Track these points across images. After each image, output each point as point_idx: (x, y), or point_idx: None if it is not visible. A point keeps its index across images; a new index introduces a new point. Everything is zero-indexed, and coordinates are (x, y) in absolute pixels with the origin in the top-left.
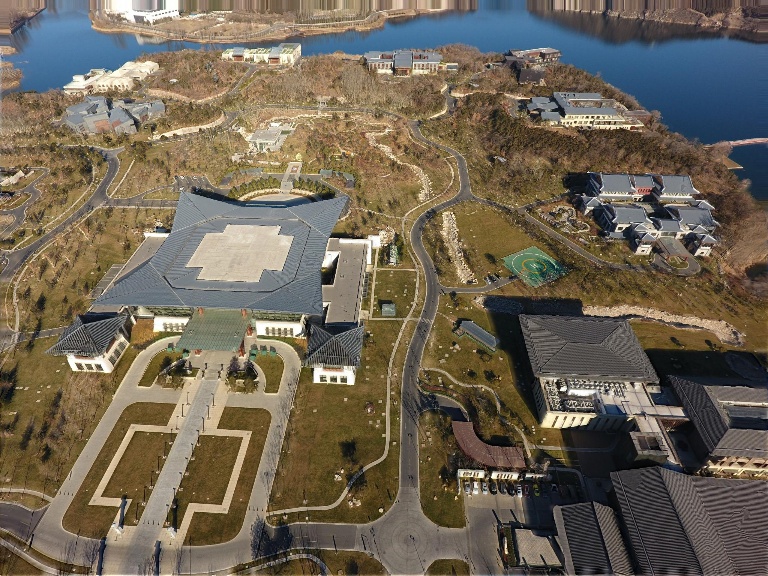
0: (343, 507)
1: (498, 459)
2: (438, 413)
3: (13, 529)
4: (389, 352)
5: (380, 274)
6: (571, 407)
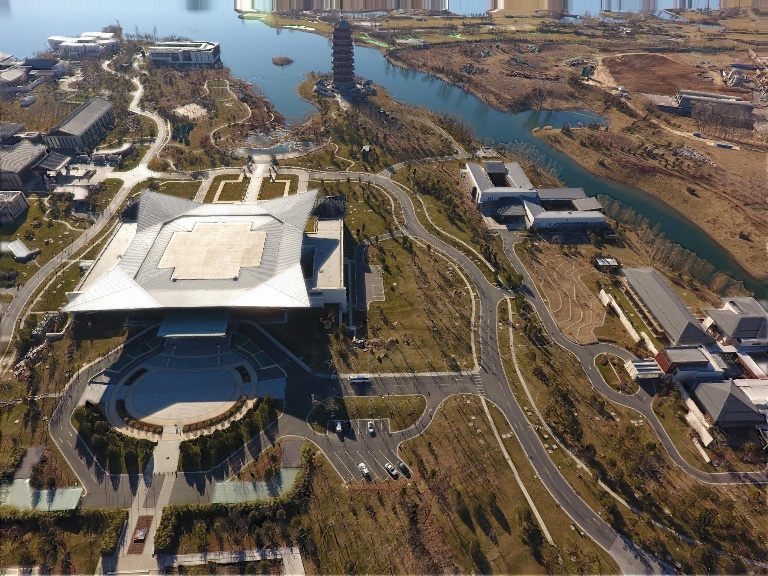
0: (164, 181)
1: (71, 188)
2: (91, 210)
3: (319, 173)
4: (106, 238)
5: None
6: (4, 195)
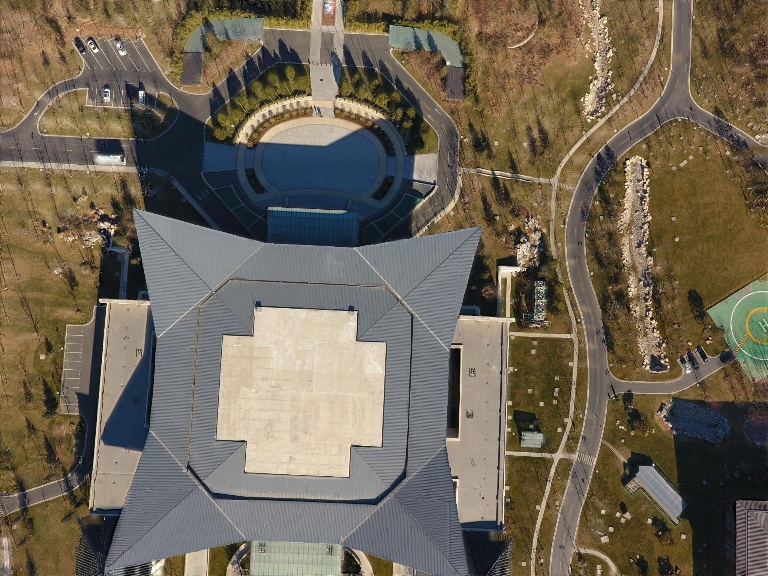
0: None
1: None
2: None
3: None
4: (533, 521)
5: (515, 348)
6: None
